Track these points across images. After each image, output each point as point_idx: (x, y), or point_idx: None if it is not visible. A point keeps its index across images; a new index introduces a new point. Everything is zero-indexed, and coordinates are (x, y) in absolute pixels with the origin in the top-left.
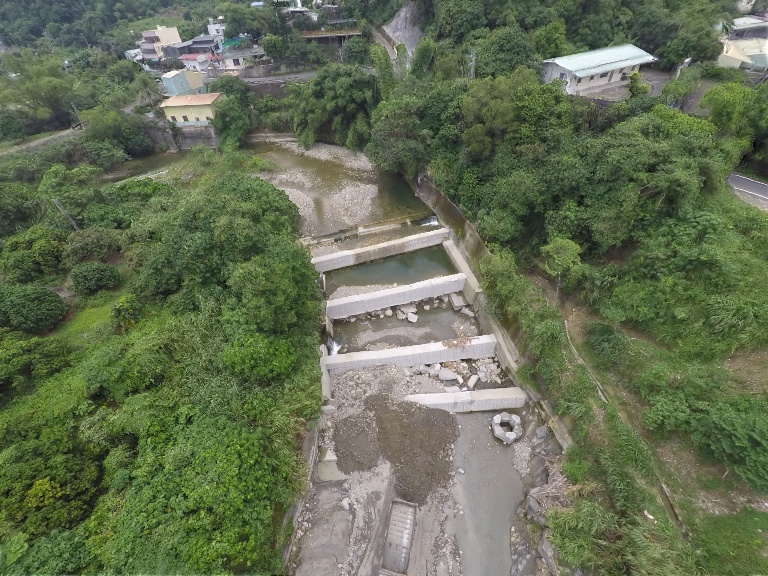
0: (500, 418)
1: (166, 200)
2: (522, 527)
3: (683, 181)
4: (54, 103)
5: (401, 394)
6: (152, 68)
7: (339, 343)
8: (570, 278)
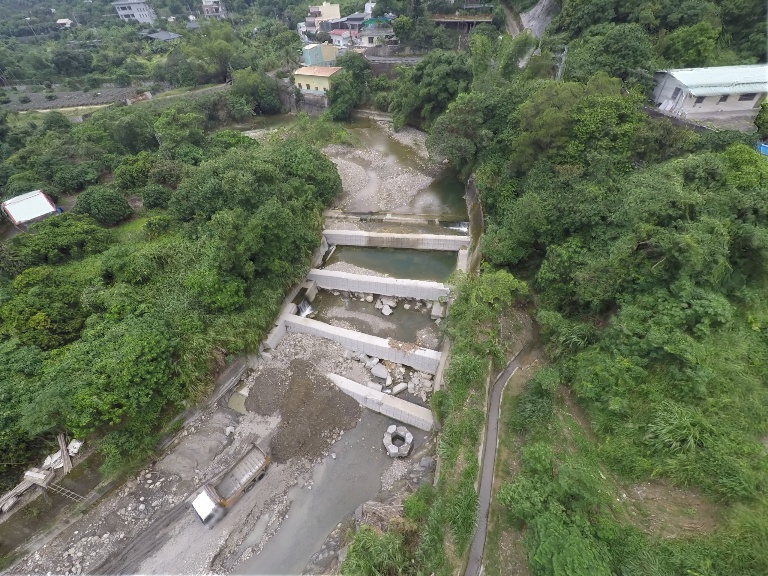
0: (394, 429)
1: (241, 151)
2: (345, 527)
3: (681, 246)
4: (224, 61)
5: (326, 369)
6: (309, 39)
7: (313, 309)
8: (545, 325)
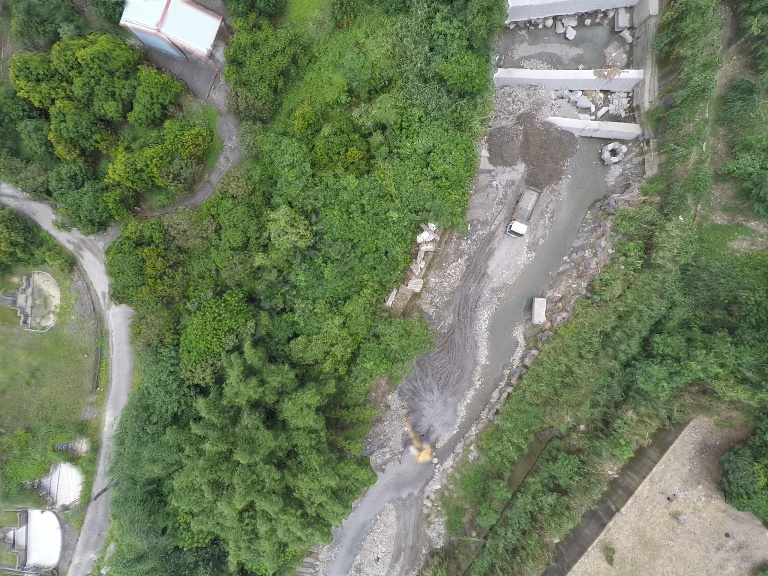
0: (613, 146)
1: None
2: (596, 212)
3: None
4: None
5: (545, 115)
6: None
7: None
8: (760, 20)
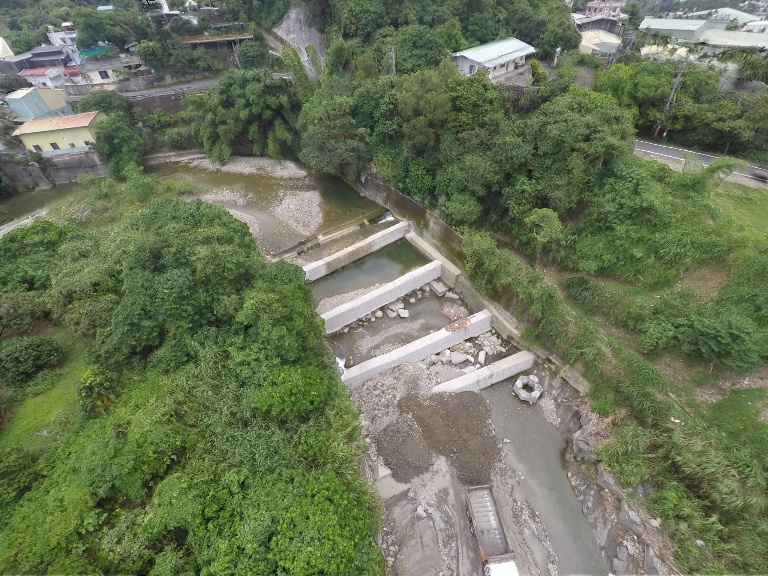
0: (521, 382)
1: (83, 244)
2: (577, 470)
3: (617, 145)
4: None
5: (427, 388)
6: None
7: (341, 357)
8: (536, 244)
